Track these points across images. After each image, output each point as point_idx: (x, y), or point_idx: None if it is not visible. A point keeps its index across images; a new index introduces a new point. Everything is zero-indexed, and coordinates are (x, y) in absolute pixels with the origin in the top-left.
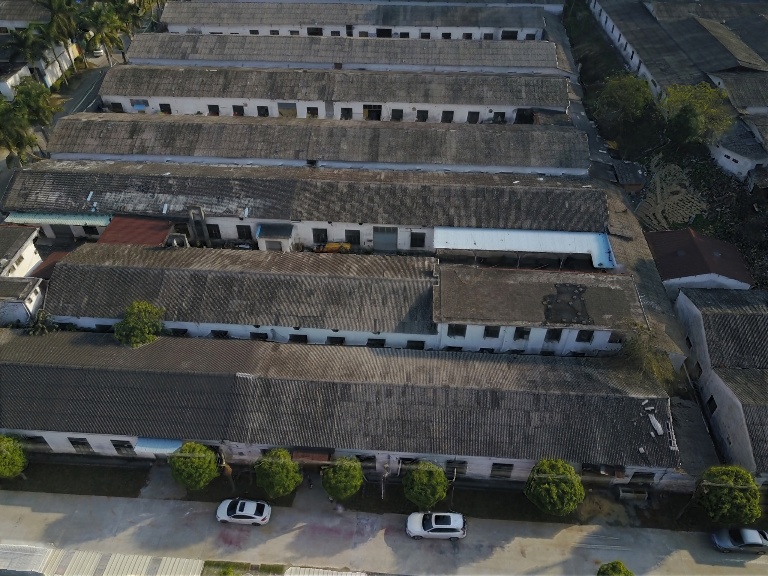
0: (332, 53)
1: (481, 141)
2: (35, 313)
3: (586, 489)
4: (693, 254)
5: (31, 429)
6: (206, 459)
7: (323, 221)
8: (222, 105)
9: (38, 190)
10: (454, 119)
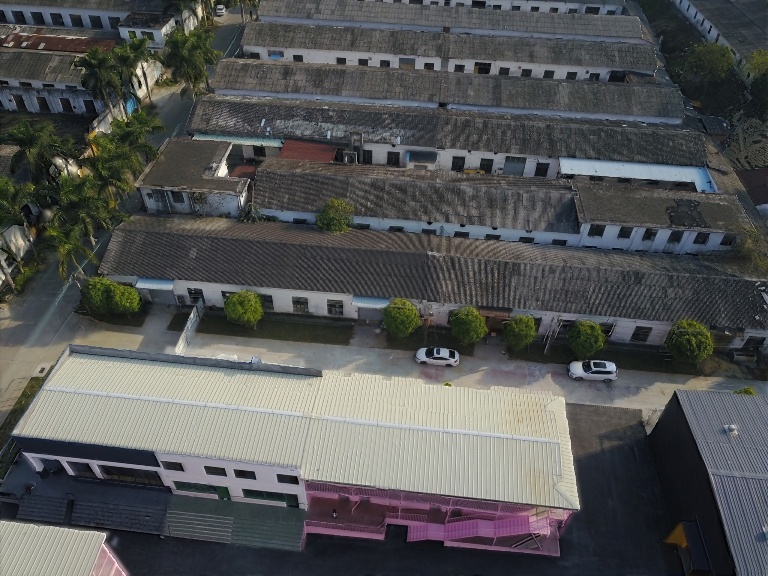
0: (441, 18)
1: (589, 93)
2: (245, 206)
3: None
4: None
5: (267, 287)
6: (413, 311)
7: (464, 150)
8: (349, 58)
9: (218, 116)
10: (554, 78)
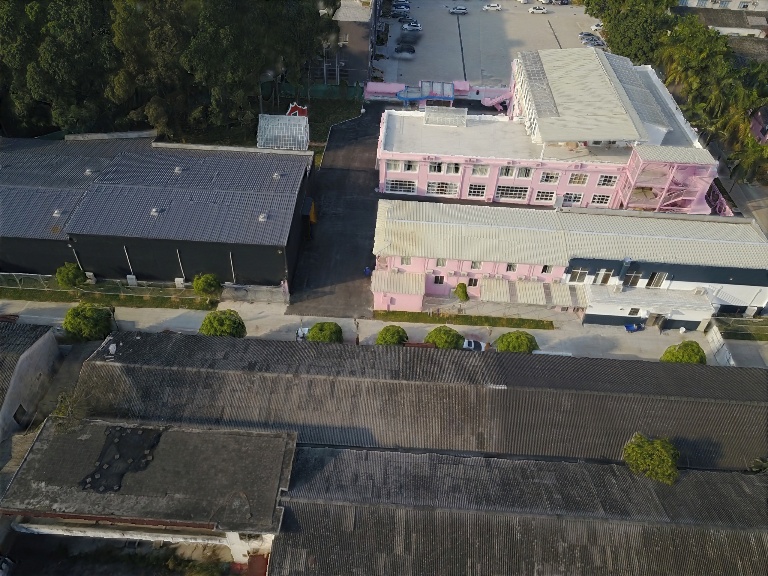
0: None
1: None
2: None
3: None
4: None
5: None
6: None
7: None
8: None
9: None
10: None
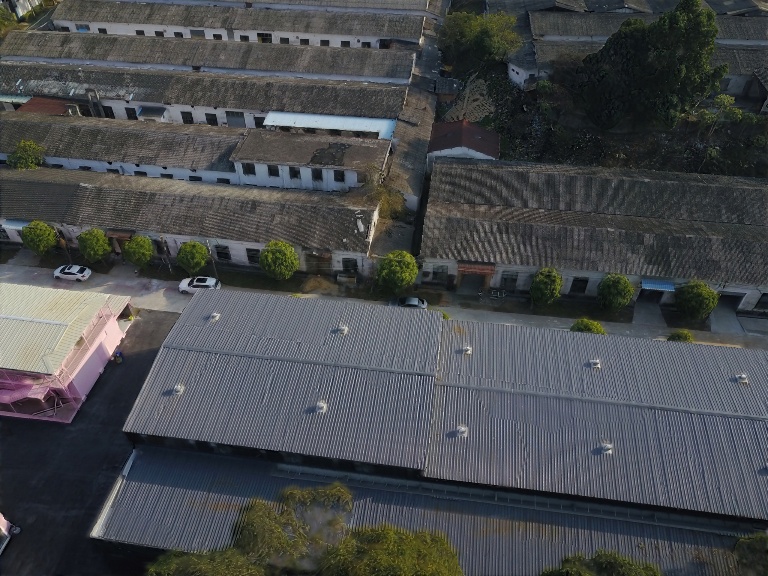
0: None
1: (329, 56)
2: None
3: (316, 275)
4: (456, 135)
5: None
6: (46, 232)
7: (187, 105)
8: (147, 31)
9: None
10: None
